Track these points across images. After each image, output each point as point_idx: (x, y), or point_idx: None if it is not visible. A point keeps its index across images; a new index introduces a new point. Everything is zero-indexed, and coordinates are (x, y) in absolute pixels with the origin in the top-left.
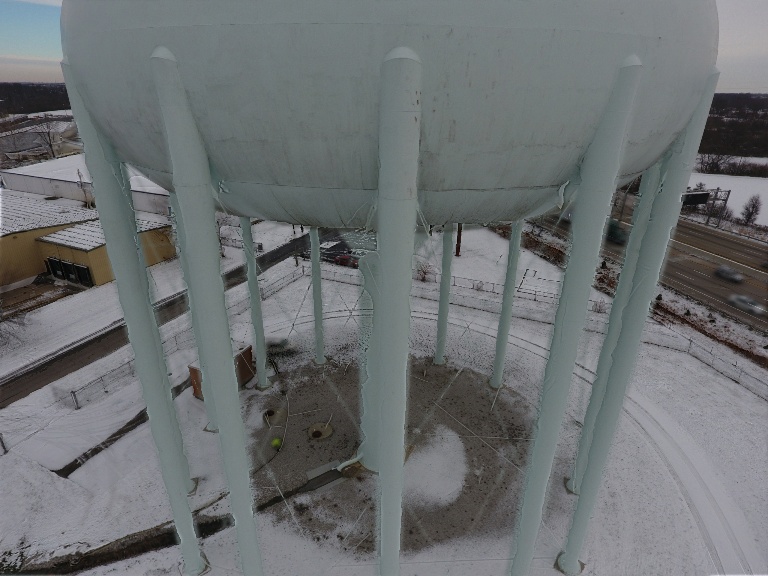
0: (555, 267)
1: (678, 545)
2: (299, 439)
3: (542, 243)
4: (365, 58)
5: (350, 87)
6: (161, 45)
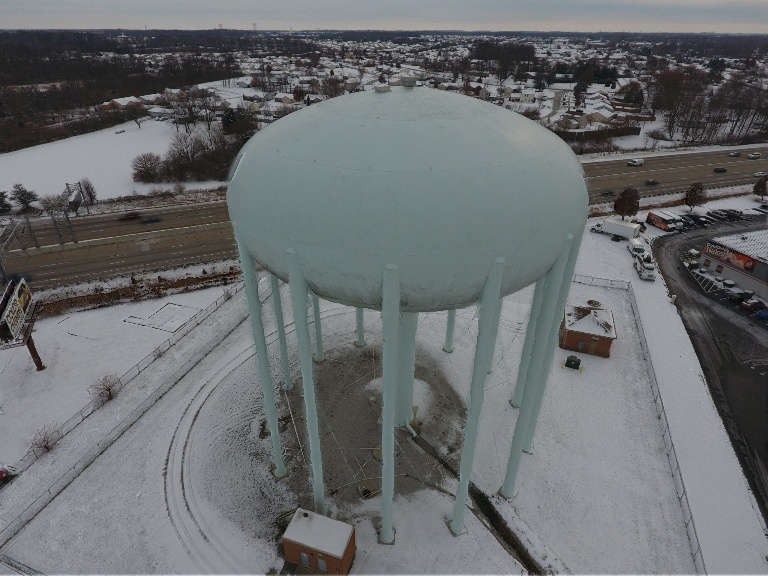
0: (128, 304)
1: None
2: None
3: (51, 303)
4: None
5: None
6: None
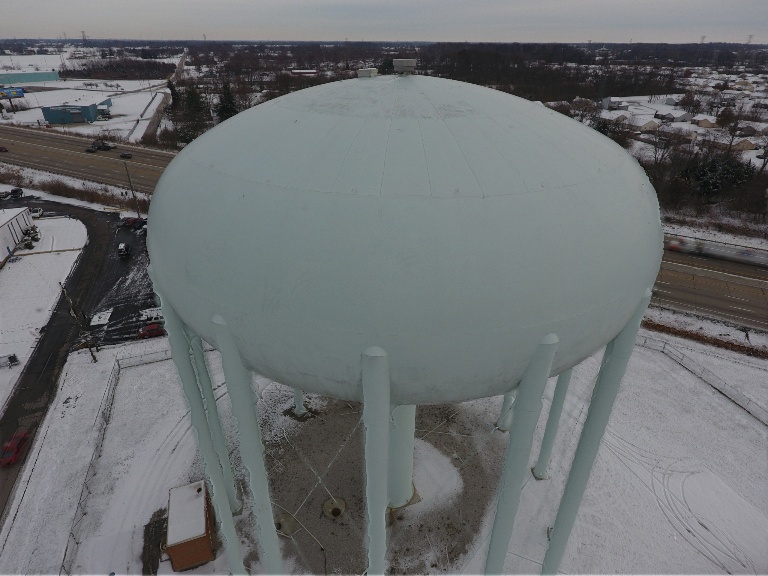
0: None
1: (562, 425)
2: (326, 527)
3: None
4: (637, 299)
5: (629, 315)
6: (551, 333)
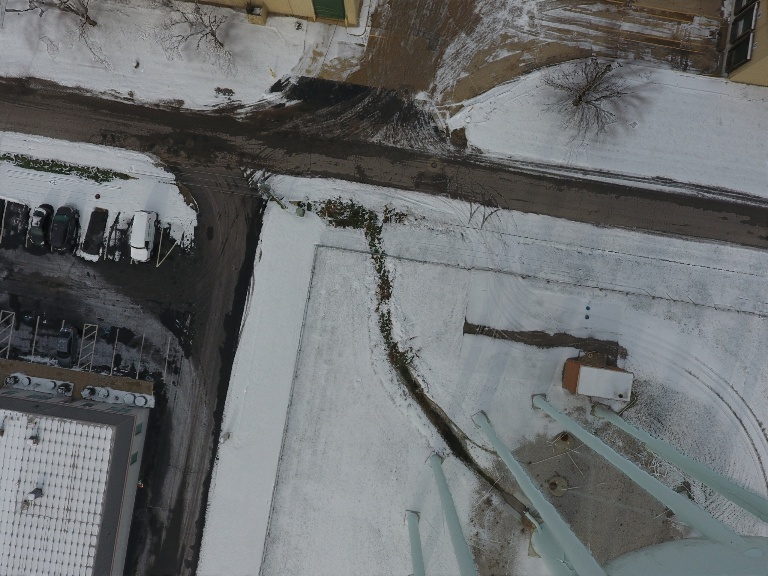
0: None
1: None
2: (546, 473)
3: None
4: None
5: None
6: None
